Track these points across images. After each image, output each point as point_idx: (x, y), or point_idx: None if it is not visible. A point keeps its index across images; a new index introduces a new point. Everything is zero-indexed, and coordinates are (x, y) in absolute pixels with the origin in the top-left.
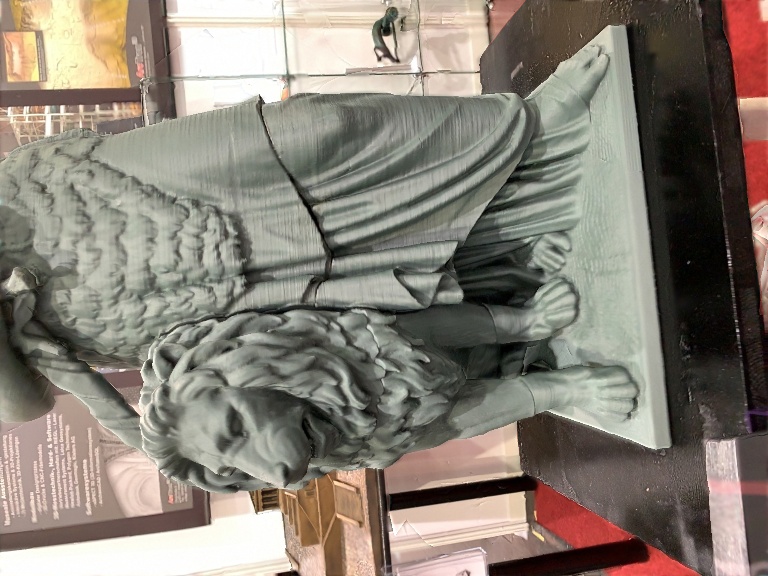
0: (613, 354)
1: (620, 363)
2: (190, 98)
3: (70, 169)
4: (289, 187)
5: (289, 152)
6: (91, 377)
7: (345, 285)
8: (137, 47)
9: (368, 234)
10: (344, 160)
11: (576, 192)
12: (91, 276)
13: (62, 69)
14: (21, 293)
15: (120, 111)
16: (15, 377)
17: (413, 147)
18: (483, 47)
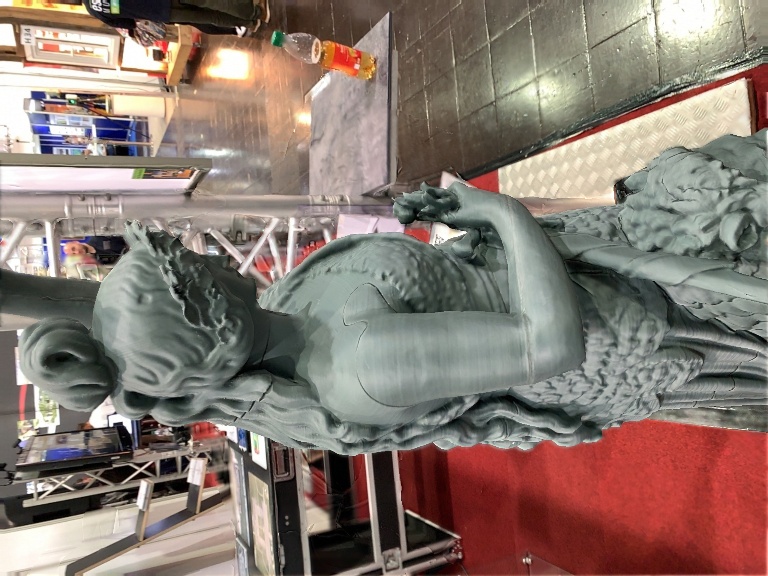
0: None
1: None
2: None
3: None
4: None
5: None
6: None
7: None
8: None
9: None
10: None
11: None
12: None
13: None
14: None
15: None
16: None
17: None
18: None
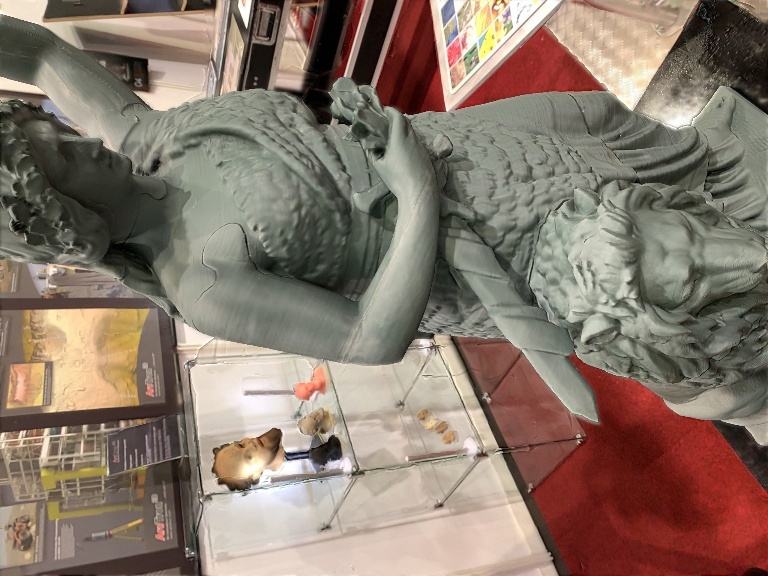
0: None
1: None
2: (198, 413)
3: (433, 113)
4: (591, 136)
5: (589, 108)
6: (493, 254)
7: None
8: (147, 371)
9: (653, 175)
10: (616, 128)
11: (751, 186)
12: (484, 161)
13: (68, 393)
14: (441, 157)
15: (127, 427)
16: (436, 236)
17: (653, 128)
18: (453, 356)
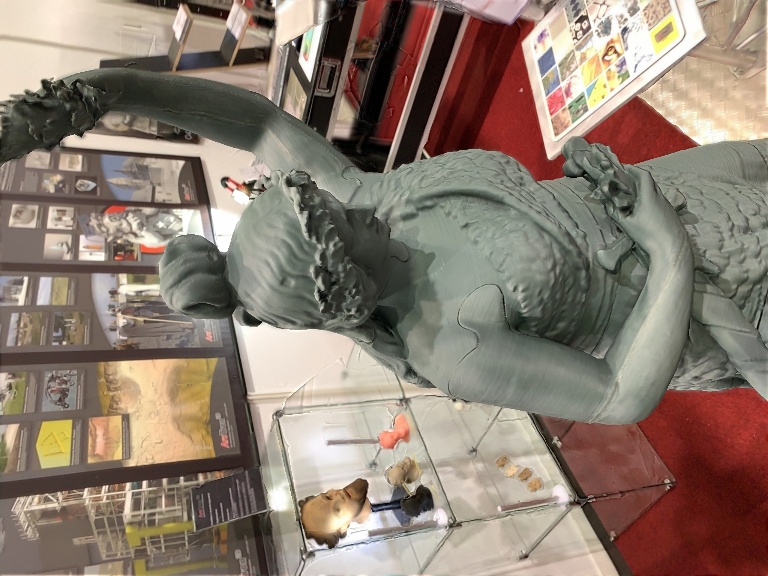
0: None
1: None
2: (273, 464)
3: None
4: None
5: None
6: None
7: None
8: (221, 421)
9: None
10: None
11: None
12: (705, 214)
13: (146, 446)
14: None
15: (206, 480)
16: None
17: None
18: None
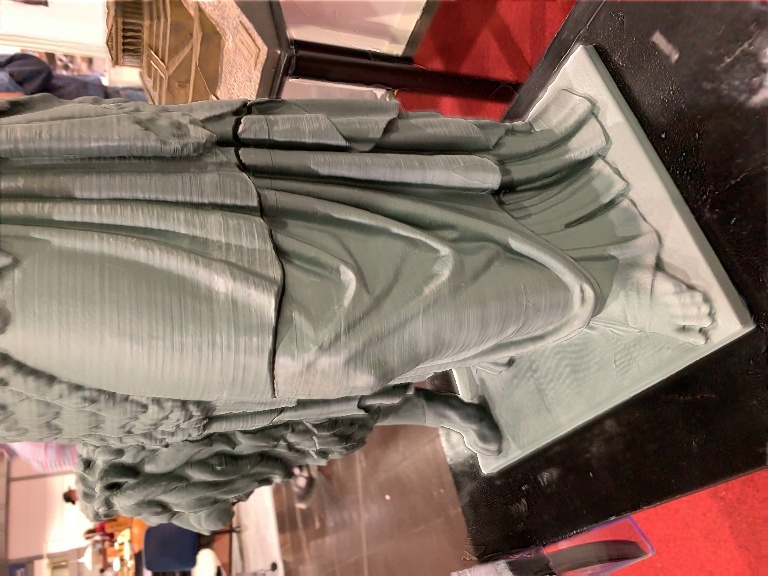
0: (502, 419)
1: (502, 429)
2: None
3: None
4: None
5: None
6: None
7: (306, 413)
8: None
9: None
10: None
11: None
12: None
13: None
14: None
15: None
16: None
17: None
18: None
